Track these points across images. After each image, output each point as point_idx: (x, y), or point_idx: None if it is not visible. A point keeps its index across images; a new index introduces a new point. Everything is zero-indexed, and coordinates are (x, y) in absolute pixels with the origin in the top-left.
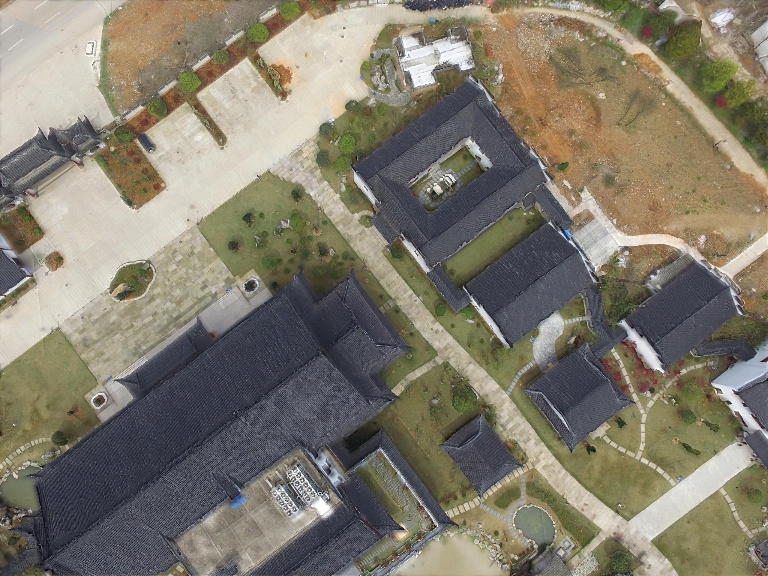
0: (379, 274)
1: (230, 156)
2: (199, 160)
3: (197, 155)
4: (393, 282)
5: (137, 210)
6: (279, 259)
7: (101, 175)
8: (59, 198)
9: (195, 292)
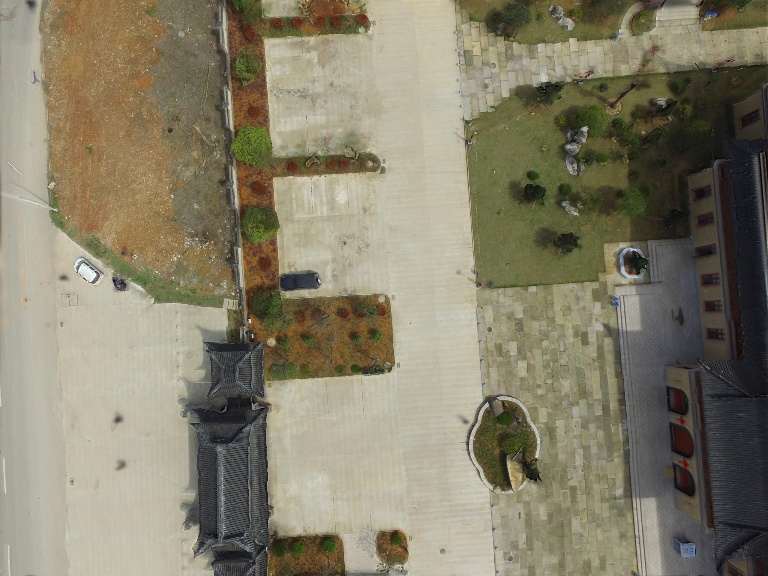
0: (735, 57)
1: (403, 166)
2: (378, 218)
3: (368, 216)
4: (762, 44)
5: (395, 365)
6: (617, 193)
7: (302, 386)
8: (295, 476)
9: (583, 357)
